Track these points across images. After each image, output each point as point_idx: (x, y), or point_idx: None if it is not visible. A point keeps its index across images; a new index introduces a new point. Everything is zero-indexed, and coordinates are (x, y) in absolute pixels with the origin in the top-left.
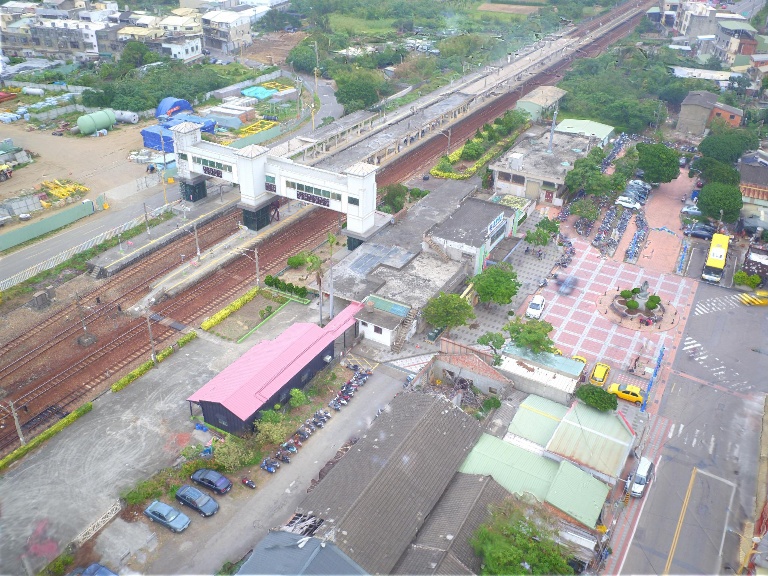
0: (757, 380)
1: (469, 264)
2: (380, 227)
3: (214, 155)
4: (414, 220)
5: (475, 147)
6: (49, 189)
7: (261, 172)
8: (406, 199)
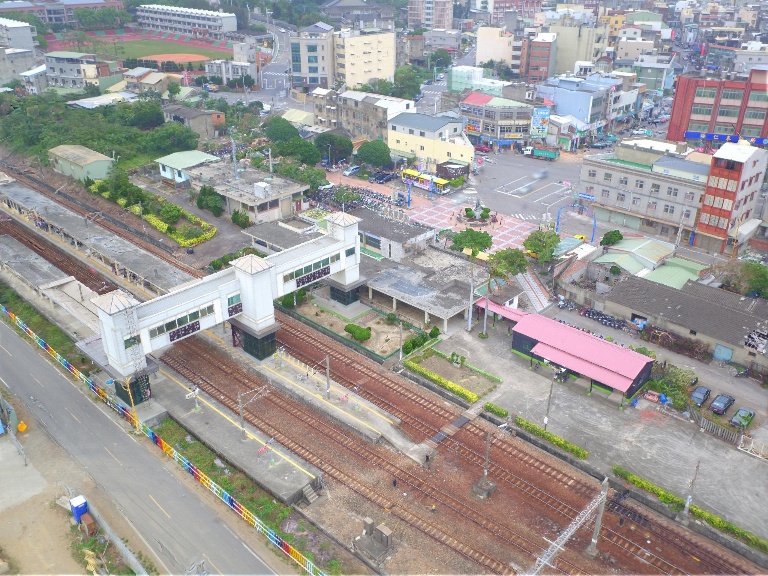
0: (556, 210)
1: None
2: None
3: (185, 306)
4: None
5: (173, 207)
6: None
7: None
8: None
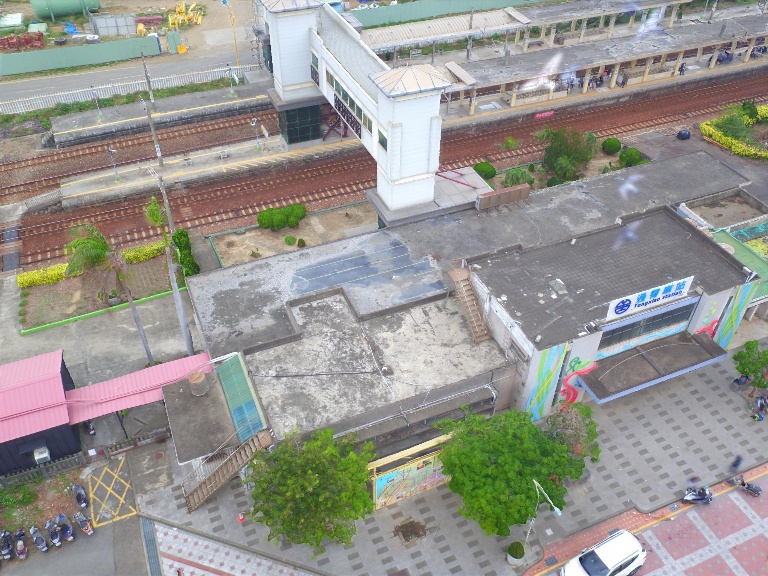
0: None
1: (518, 370)
2: (439, 208)
3: None
4: (532, 215)
5: None
6: (173, 13)
7: (301, 44)
8: (585, 165)
